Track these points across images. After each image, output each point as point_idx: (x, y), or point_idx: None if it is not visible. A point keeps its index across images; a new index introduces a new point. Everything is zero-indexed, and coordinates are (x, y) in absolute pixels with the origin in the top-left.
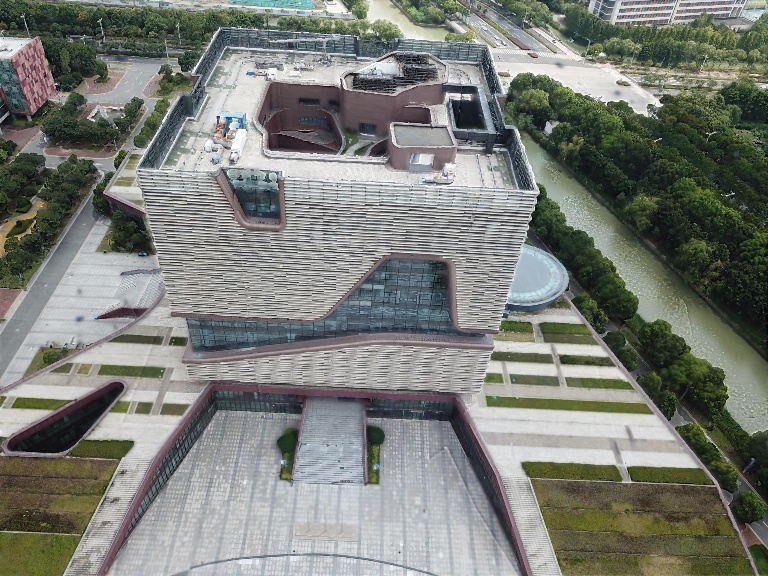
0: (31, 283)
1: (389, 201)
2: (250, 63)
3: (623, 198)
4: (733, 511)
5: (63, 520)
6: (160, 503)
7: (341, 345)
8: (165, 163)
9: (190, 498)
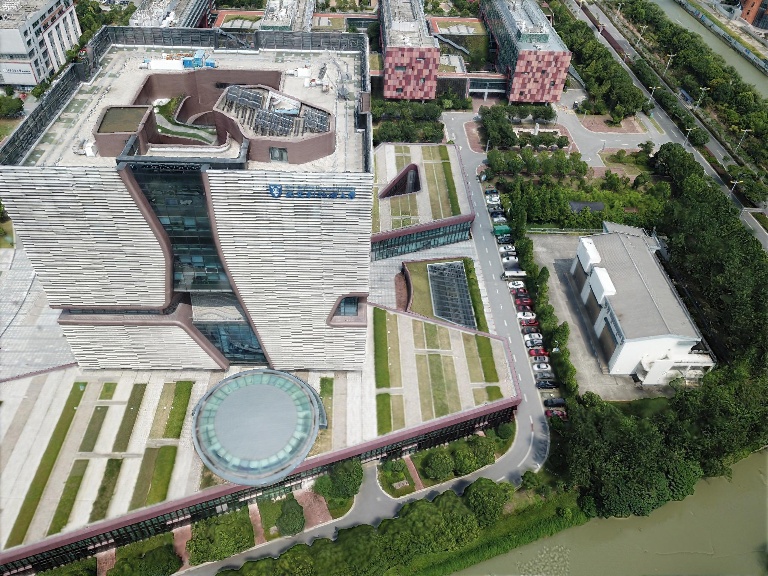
0: None
1: None
2: (334, 65)
3: None
4: None
5: None
6: None
7: None
8: (149, 48)
9: None
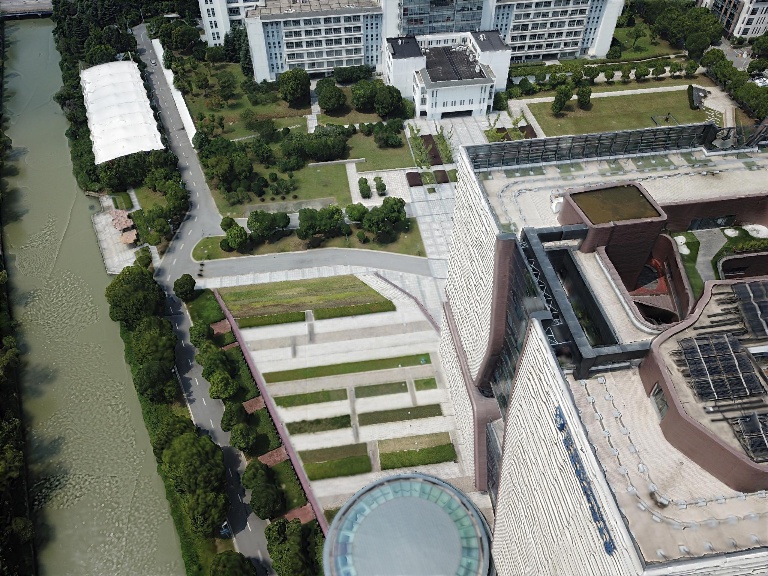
0: None
1: None
2: None
3: None
4: None
5: None
6: None
7: None
8: None
9: None
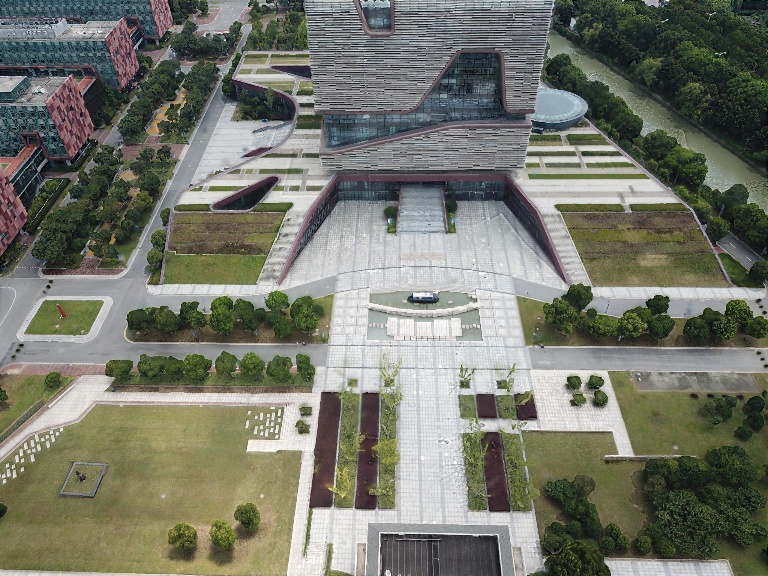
0: (190, 140)
1: (460, 7)
2: None
3: (635, 65)
4: (706, 233)
5: (254, 247)
6: (311, 246)
7: (427, 131)
8: None
9: (330, 243)
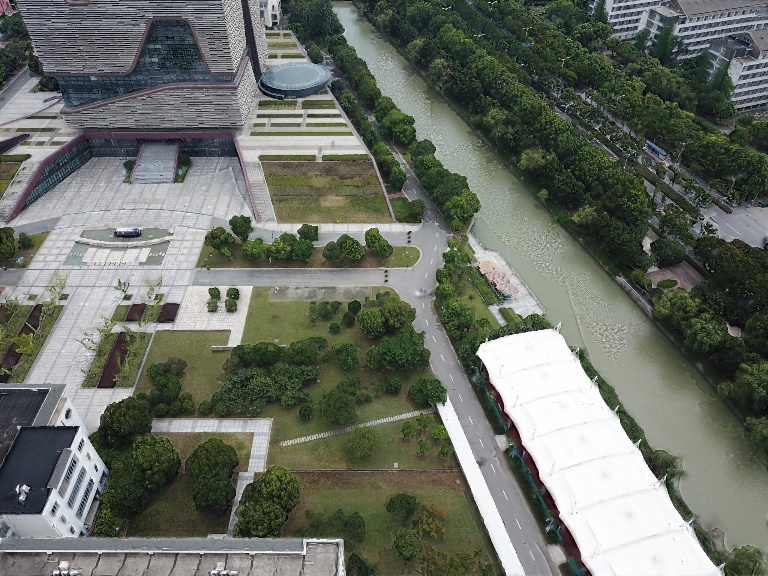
0: None
1: None
2: None
3: None
4: None
5: None
6: (50, 193)
7: (148, 92)
8: None
9: (68, 191)
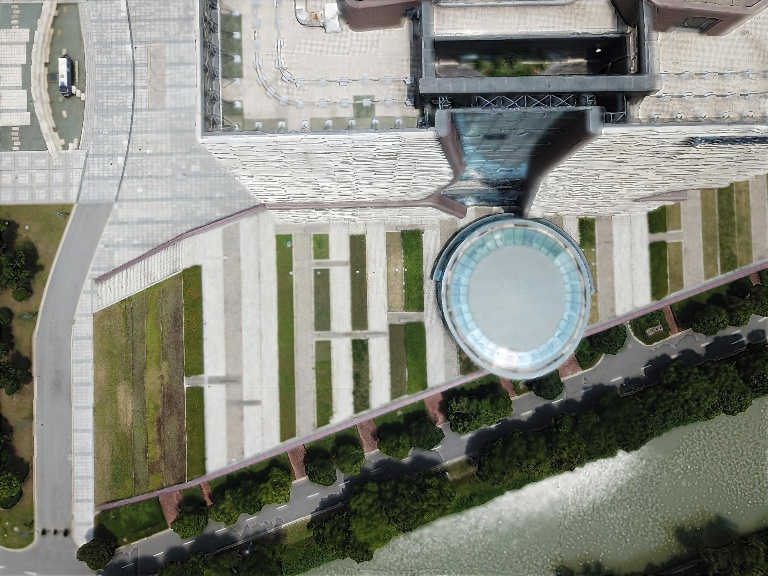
0: None
1: None
2: None
3: None
4: None
5: None
6: None
7: None
8: None
9: None
